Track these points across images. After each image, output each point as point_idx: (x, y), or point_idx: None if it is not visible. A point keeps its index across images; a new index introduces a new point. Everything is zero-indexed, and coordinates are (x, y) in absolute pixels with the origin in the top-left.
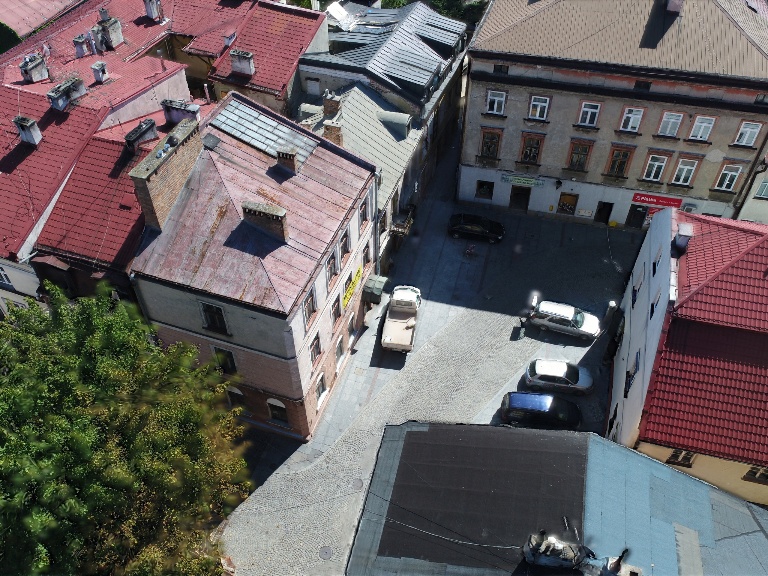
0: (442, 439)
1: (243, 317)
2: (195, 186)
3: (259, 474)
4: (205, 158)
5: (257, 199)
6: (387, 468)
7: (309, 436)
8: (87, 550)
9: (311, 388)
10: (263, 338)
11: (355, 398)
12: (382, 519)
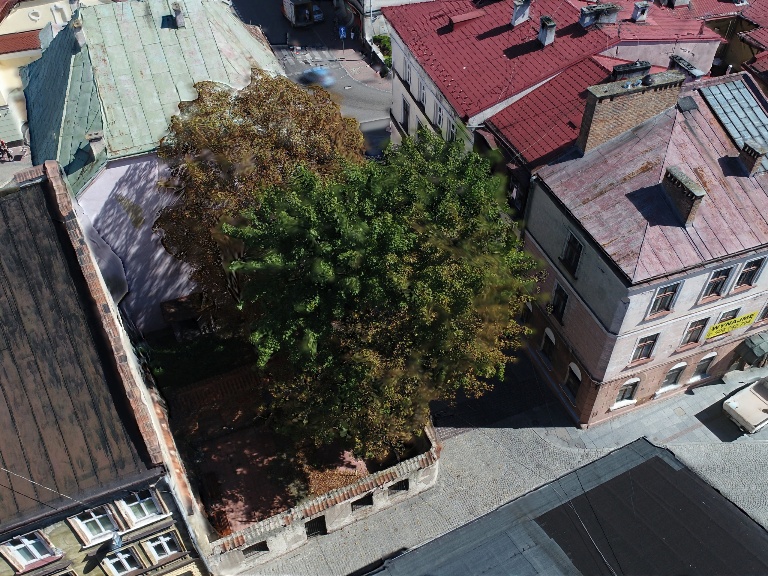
0: (685, 487)
1: (595, 265)
2: (641, 134)
3: (520, 419)
4: (670, 115)
5: (689, 175)
6: (609, 467)
7: (585, 425)
8: (344, 330)
9: (616, 381)
10: (600, 297)
11: (655, 429)
12: (565, 498)
